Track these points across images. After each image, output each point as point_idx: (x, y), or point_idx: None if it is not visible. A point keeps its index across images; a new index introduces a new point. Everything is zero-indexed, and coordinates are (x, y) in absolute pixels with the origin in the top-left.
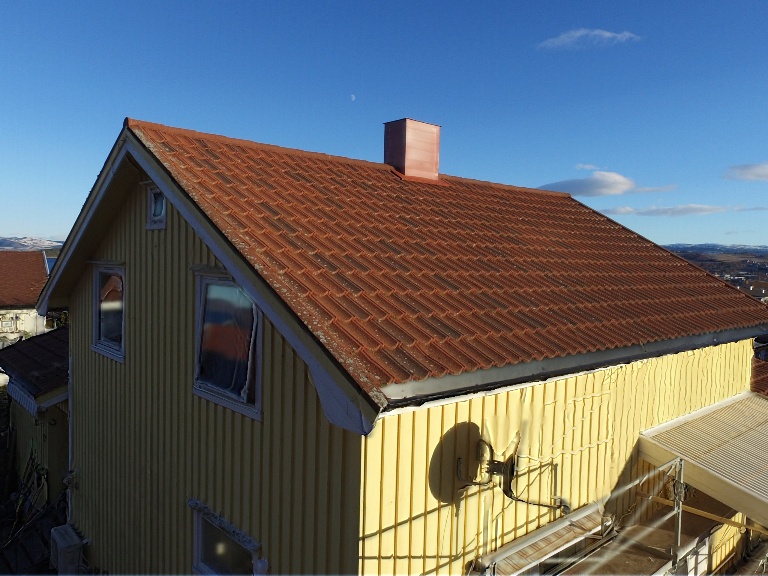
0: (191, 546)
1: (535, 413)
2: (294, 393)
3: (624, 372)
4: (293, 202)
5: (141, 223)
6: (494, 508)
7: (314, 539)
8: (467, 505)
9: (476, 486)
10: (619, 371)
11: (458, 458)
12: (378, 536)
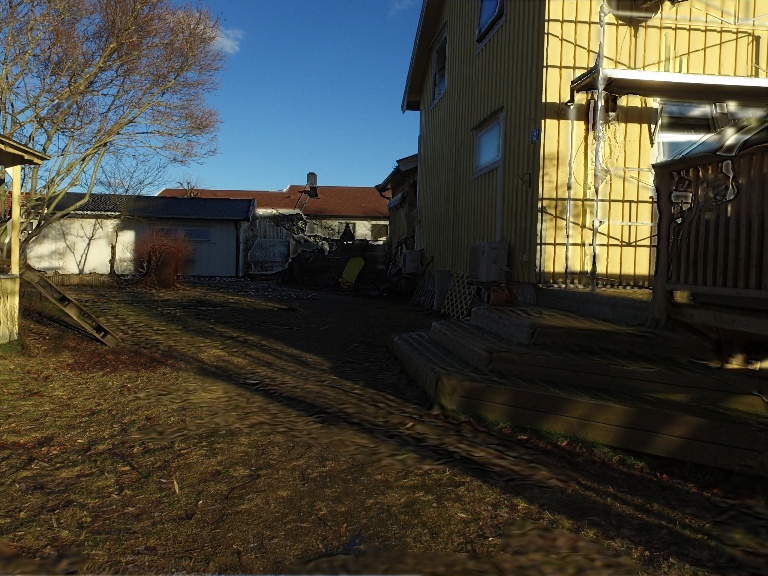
0: (472, 164)
1: None
2: None
3: None
4: None
5: None
6: (677, 47)
7: None
8: (646, 33)
9: (656, 20)
10: None
11: None
12: (561, 24)
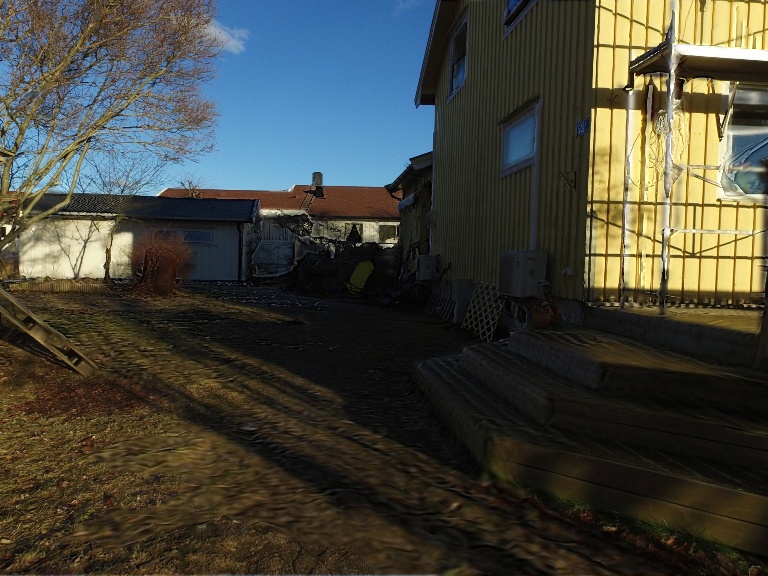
0: (499, 161)
1: None
2: None
3: None
4: None
5: None
6: (750, 23)
7: (570, 37)
8: (715, 7)
9: None
10: None
11: None
12: None
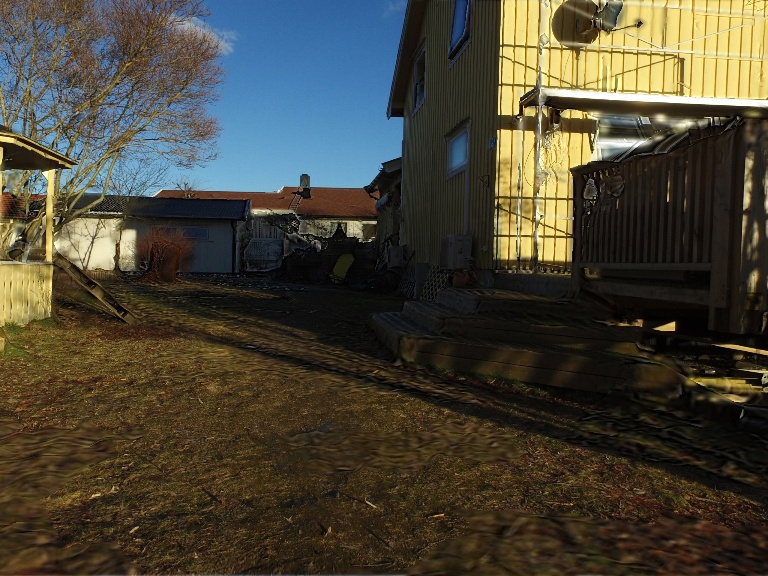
0: None
1: (656, 11)
2: (482, 4)
3: None
4: None
5: (433, 2)
6: (613, 67)
7: None
8: (587, 56)
9: (595, 45)
10: (767, 3)
11: (577, 20)
12: (513, 49)
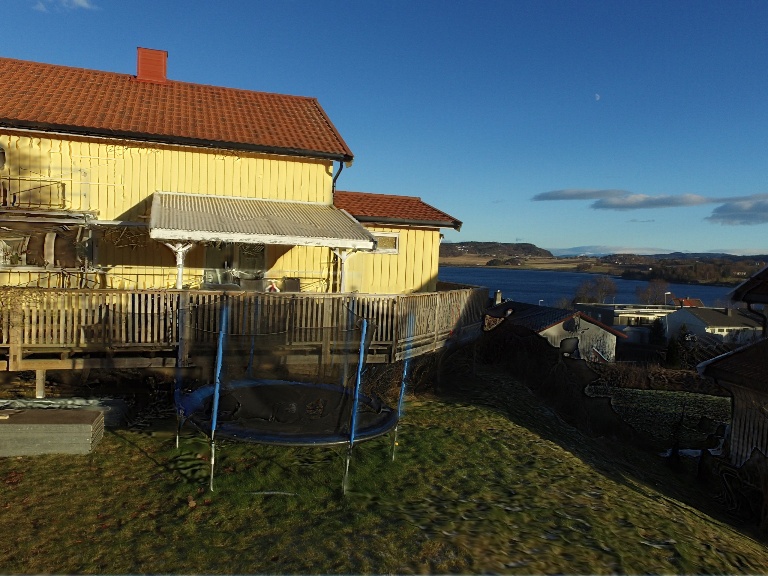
0: None
1: (43, 154)
2: None
3: (129, 152)
4: (1, 78)
5: None
6: (11, 189)
7: None
8: None
9: None
10: (124, 150)
11: None
12: None
